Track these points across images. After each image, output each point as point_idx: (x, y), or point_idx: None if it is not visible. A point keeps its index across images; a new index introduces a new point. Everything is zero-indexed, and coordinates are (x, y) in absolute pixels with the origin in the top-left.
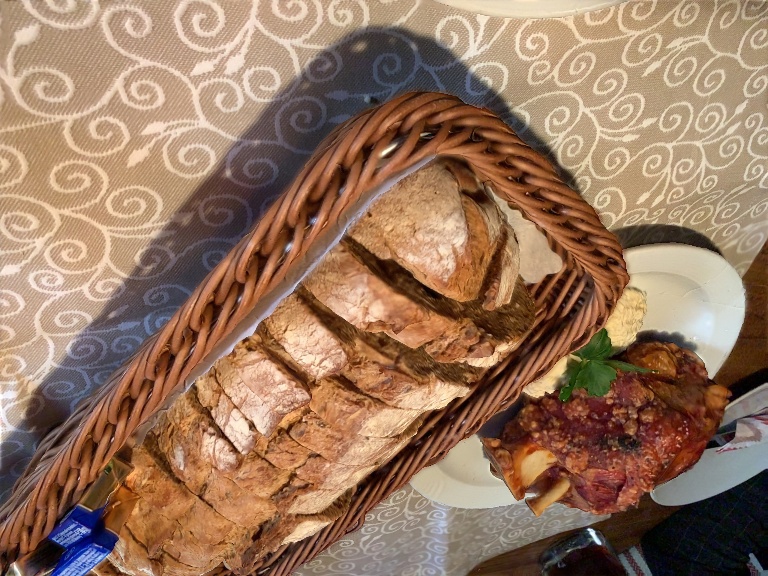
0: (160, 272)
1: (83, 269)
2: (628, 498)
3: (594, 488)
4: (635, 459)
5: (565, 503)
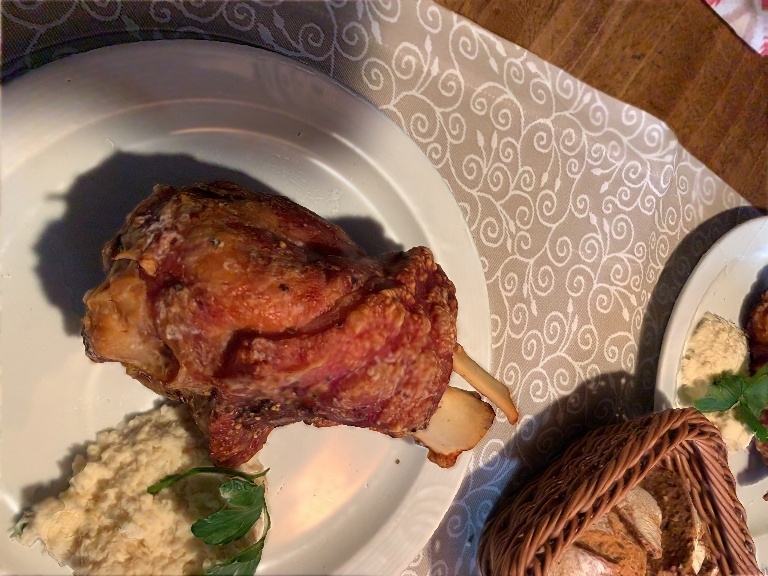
0: None
1: None
2: None
3: None
4: None
5: None
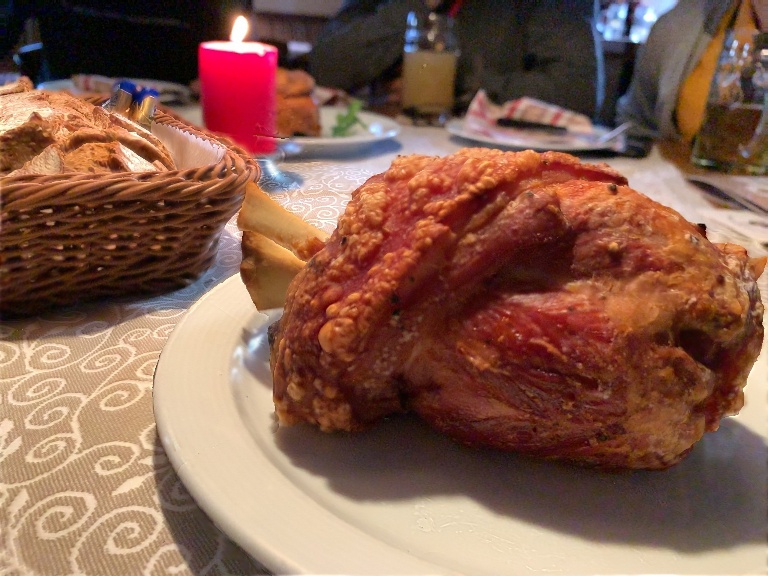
0: None
1: None
2: None
3: None
4: None
5: None
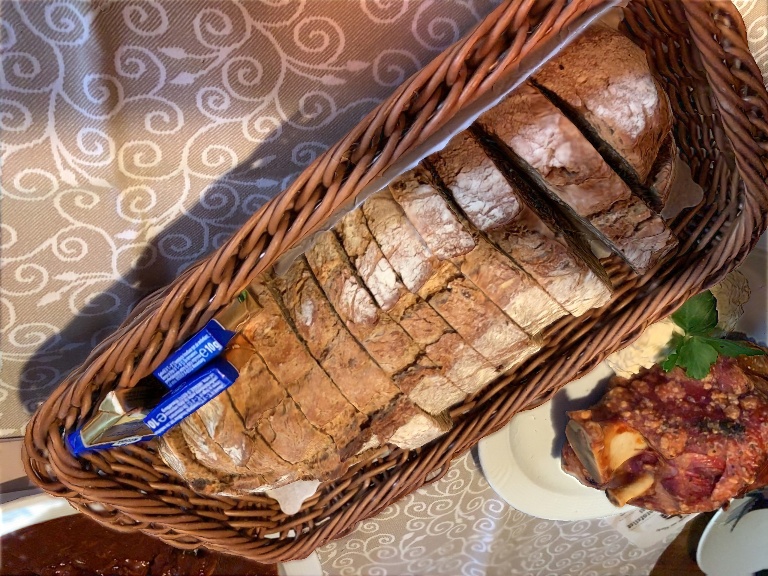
0: (317, 125)
1: (251, 97)
2: (726, 490)
3: (687, 478)
4: (738, 444)
5: (645, 503)
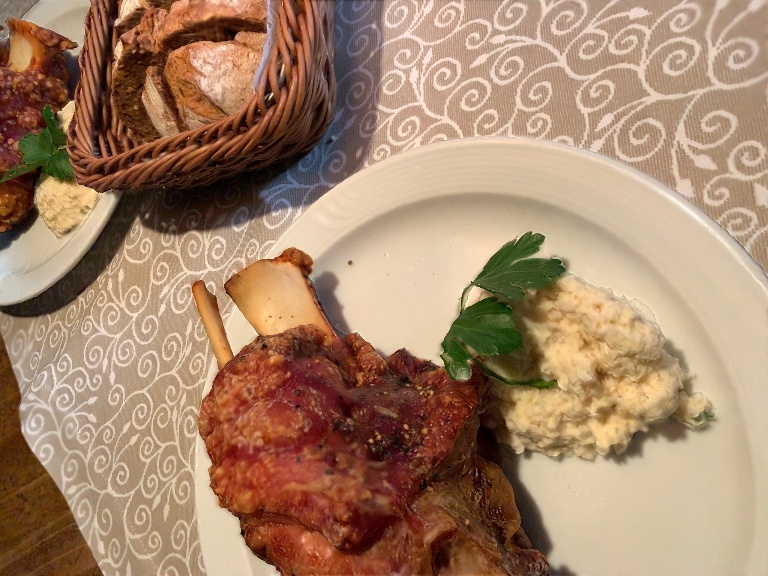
0: None
1: None
2: None
3: None
4: None
5: None
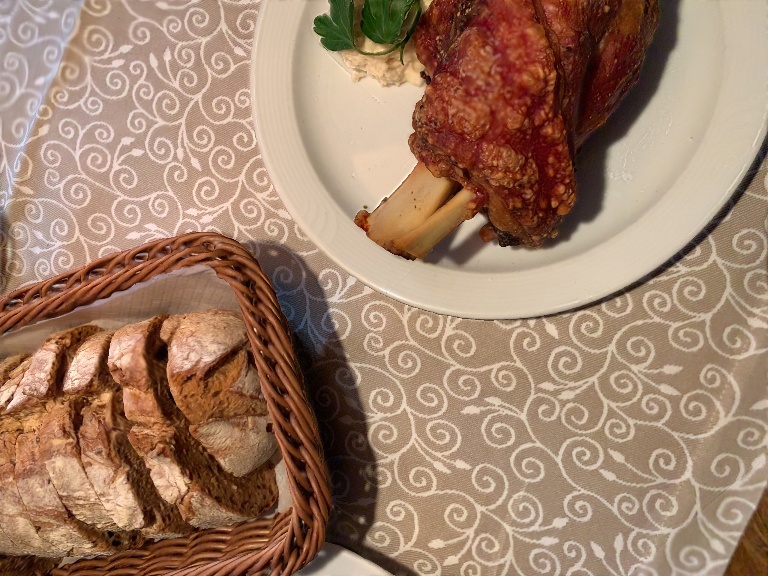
0: None
1: None
2: None
3: None
4: None
5: None
